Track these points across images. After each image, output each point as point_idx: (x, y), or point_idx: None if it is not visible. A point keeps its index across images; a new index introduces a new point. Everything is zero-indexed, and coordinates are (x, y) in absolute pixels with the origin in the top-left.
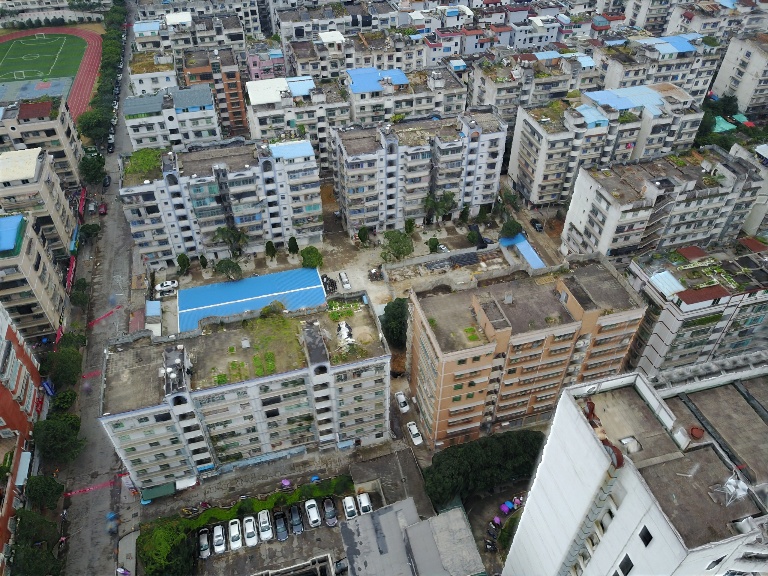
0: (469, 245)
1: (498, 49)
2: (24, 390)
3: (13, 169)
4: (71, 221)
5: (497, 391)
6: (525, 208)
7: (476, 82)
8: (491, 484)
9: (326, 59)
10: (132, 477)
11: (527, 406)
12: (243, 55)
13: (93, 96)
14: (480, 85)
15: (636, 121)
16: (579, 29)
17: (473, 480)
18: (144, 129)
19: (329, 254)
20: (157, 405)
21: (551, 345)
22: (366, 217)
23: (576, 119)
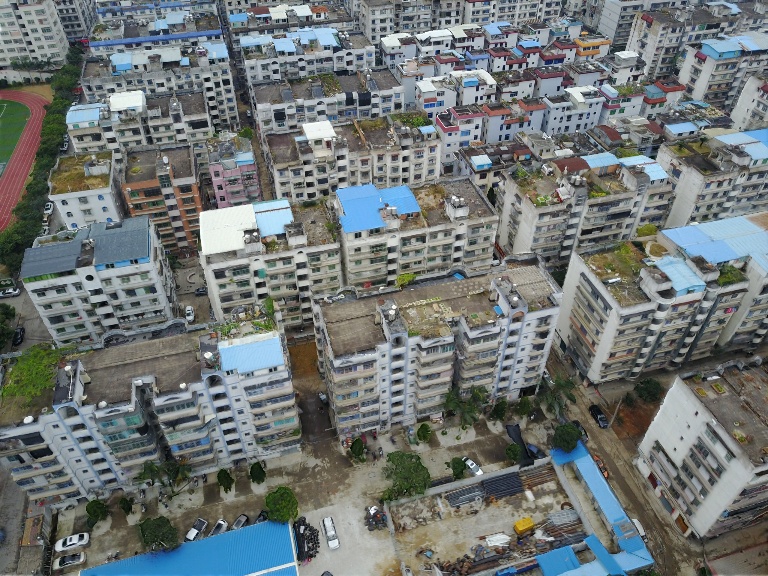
0: (507, 455)
1: (531, 138)
2: None
3: None
4: None
5: None
6: (580, 383)
7: (508, 196)
8: None
9: (311, 162)
10: None
11: None
12: None
13: (24, 193)
14: (514, 203)
15: (742, 281)
16: (628, 103)
17: None
18: (53, 292)
19: (310, 474)
20: None
21: None
22: (362, 423)
23: (660, 285)
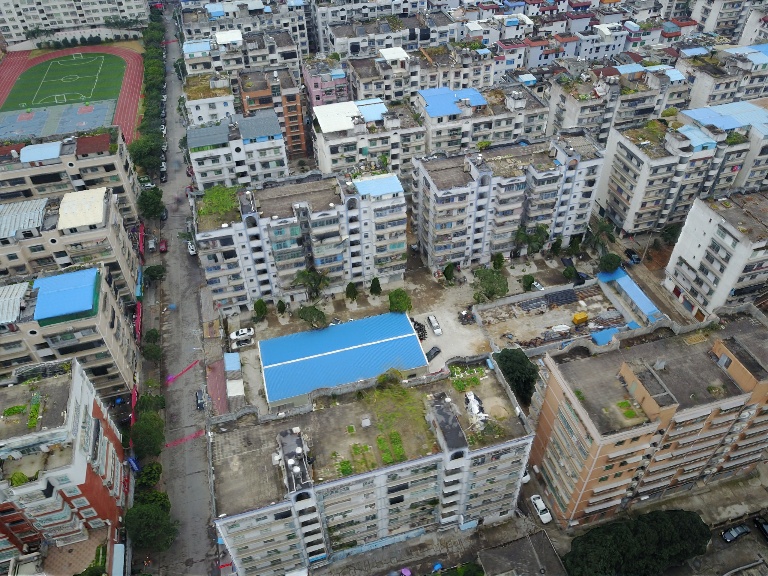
0: (563, 281)
1: (568, 61)
2: (113, 472)
3: (79, 213)
4: (135, 263)
5: (645, 467)
6: (616, 236)
7: (553, 99)
8: (644, 575)
9: (390, 78)
10: (240, 574)
11: (671, 479)
12: (296, 74)
13: (139, 120)
14: (559, 103)
15: (744, 142)
16: (648, 36)
17: (625, 573)
18: (209, 162)
19: (412, 294)
20: (278, 503)
21: (714, 418)
22: (452, 253)
23: (681, 142)
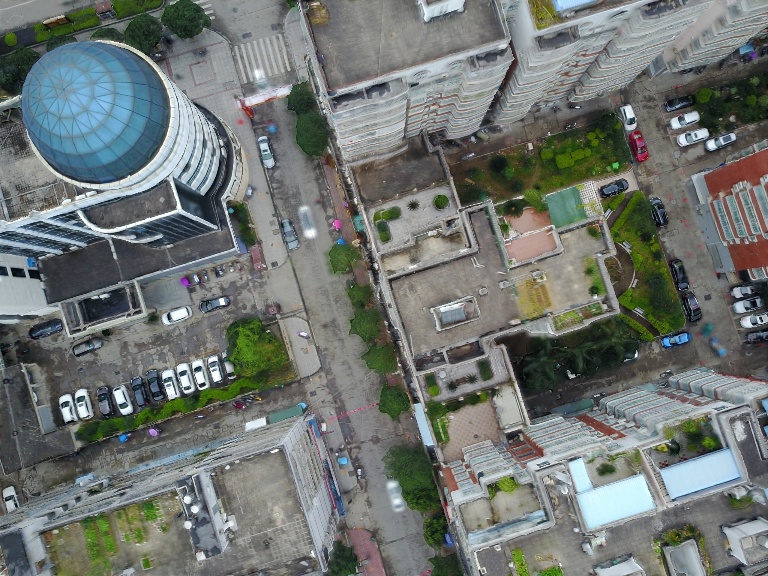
0: None
1: None
2: None
3: None
4: None
5: None
6: None
7: None
8: None
9: None
10: (301, 420)
11: None
12: None
13: None
14: None
15: None
16: None
17: None
18: None
19: None
20: None
21: None
22: None
23: None
